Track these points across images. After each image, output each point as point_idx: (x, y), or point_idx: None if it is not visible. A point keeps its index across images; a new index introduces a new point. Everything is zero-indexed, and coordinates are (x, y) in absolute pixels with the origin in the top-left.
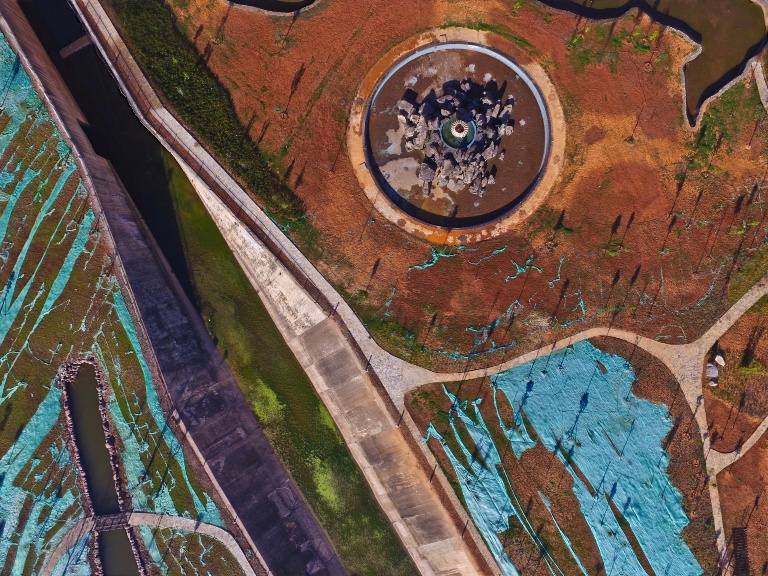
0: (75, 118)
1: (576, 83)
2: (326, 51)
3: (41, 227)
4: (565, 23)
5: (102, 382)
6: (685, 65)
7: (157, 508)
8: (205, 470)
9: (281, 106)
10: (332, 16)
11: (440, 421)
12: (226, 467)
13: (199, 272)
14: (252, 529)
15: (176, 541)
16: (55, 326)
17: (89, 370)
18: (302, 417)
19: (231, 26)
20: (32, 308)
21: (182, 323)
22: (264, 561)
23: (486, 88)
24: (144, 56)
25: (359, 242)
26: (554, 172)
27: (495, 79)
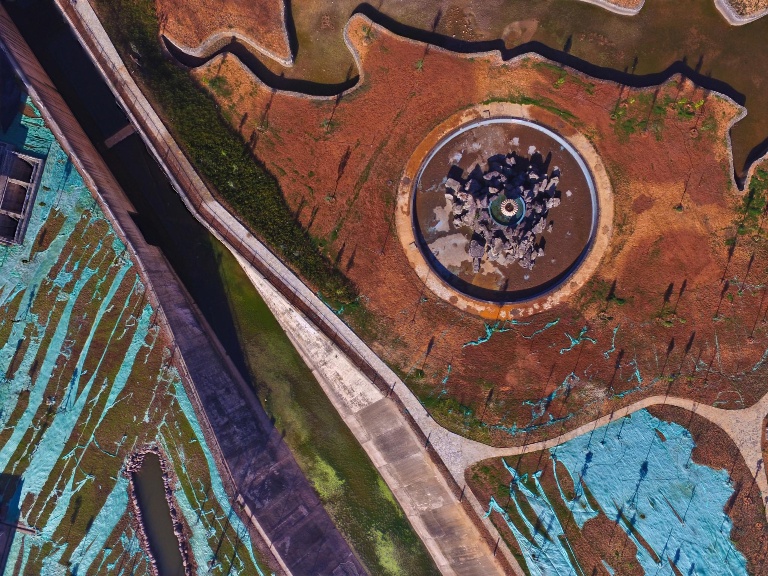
0: (126, 211)
1: (622, 152)
2: (371, 133)
3: (101, 324)
4: (608, 93)
5: (167, 471)
6: (730, 127)
7: None
8: (272, 552)
9: (329, 190)
10: (375, 98)
11: (501, 495)
12: (291, 547)
13: (253, 353)
14: None
15: None
16: (119, 419)
17: (153, 459)
18: (361, 492)
19: (275, 113)
20: (96, 403)
21: (240, 406)
22: None
23: (531, 161)
24: (193, 150)
25: (413, 322)
26: (603, 242)
27: (540, 151)
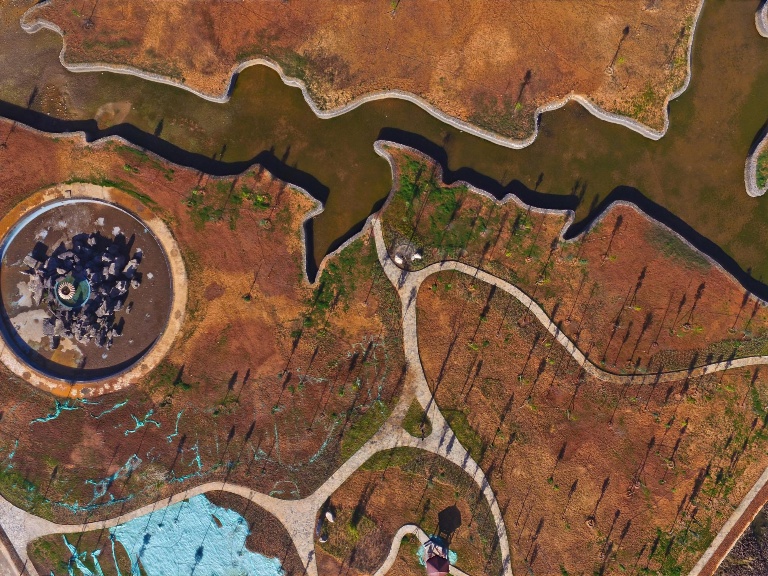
0: None
1: (197, 239)
2: None
3: None
4: (187, 180)
5: None
6: (312, 219)
7: None
8: None
9: None
10: None
11: (60, 571)
12: None
13: None
14: None
15: None
16: None
17: None
18: None
19: None
20: None
21: None
22: None
23: (115, 241)
24: None
25: None
26: (175, 327)
27: (124, 232)
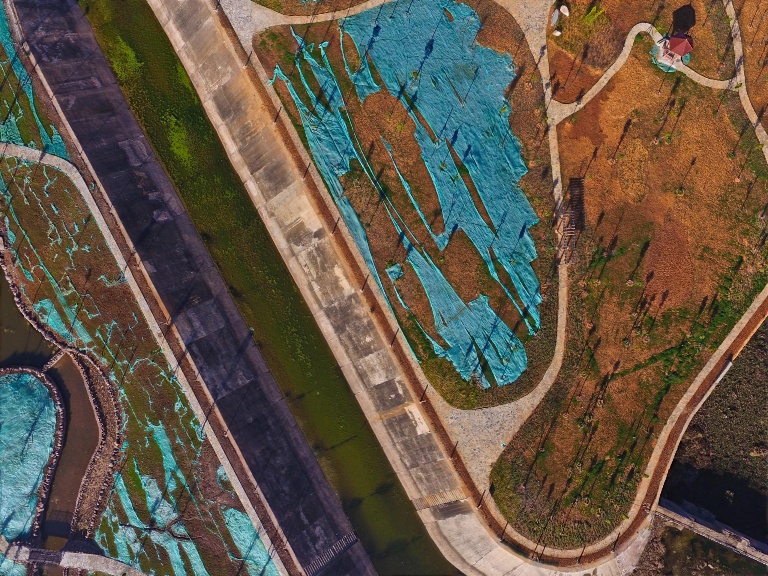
0: None
1: None
2: None
3: None
4: None
5: None
6: None
7: (3, 136)
8: (53, 103)
9: None
10: None
11: (286, 63)
12: (76, 106)
13: None
14: (98, 166)
15: (21, 171)
16: None
17: None
18: (159, 76)
19: None
20: None
21: None
22: (107, 196)
23: None
24: None
25: None
26: None
27: None
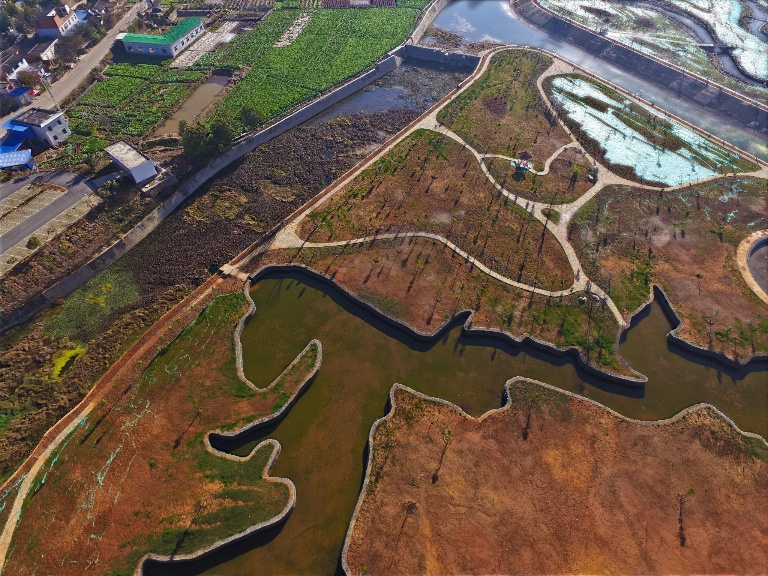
0: None
1: (760, 312)
2: None
3: None
4: None
5: None
6: None
7: None
8: None
9: None
10: None
11: None
12: None
13: None
14: None
15: None
16: None
17: None
18: None
19: None
20: None
21: None
22: None
23: None
24: None
25: None
26: (741, 262)
27: None
